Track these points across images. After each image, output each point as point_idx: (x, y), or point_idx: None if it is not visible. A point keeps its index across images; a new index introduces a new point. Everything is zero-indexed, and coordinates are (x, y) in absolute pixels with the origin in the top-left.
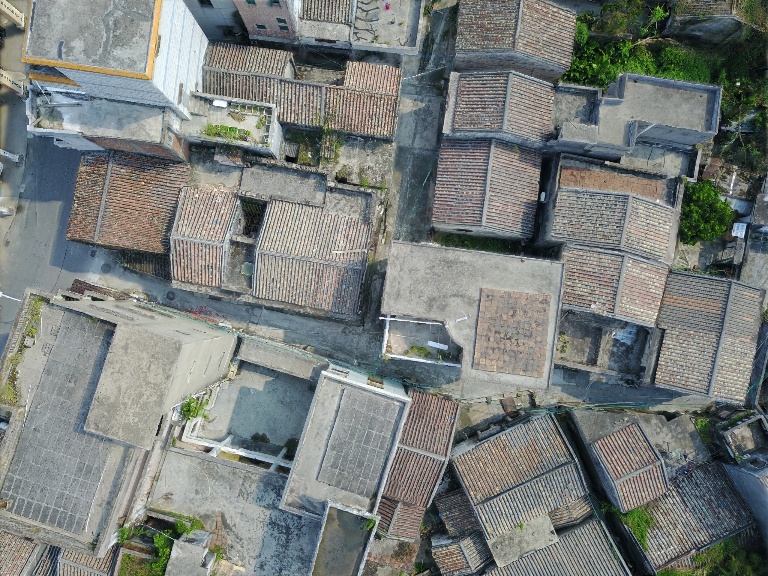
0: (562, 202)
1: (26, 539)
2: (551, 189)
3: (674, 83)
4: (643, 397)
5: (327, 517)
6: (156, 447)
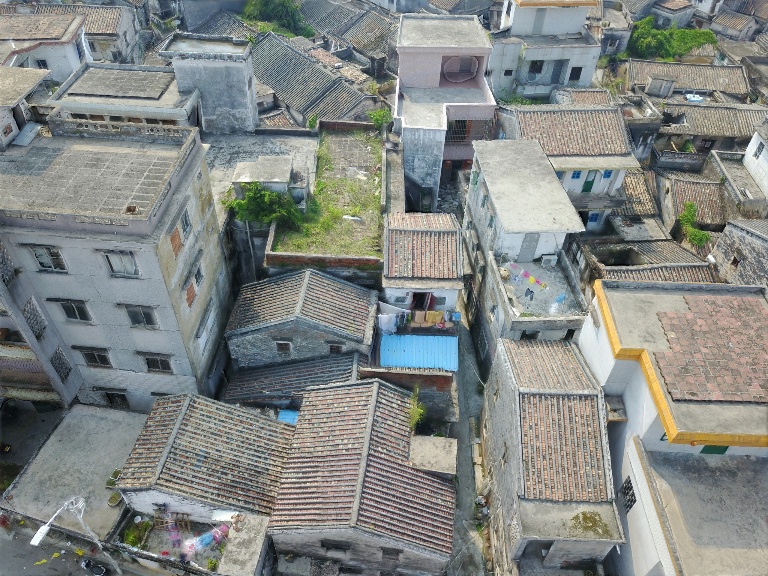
0: None
1: None
2: None
3: None
4: None
5: None
6: None
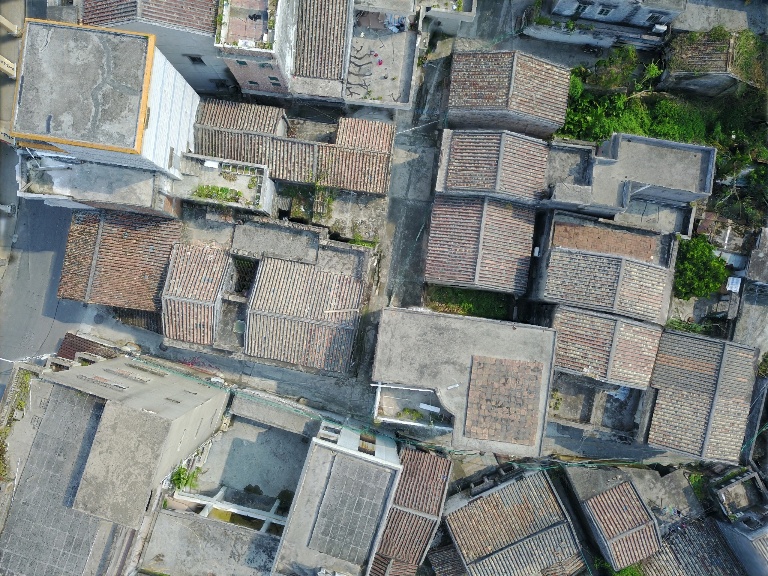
0: (555, 262)
1: None
2: (544, 246)
3: (668, 143)
4: (637, 449)
5: None
6: None
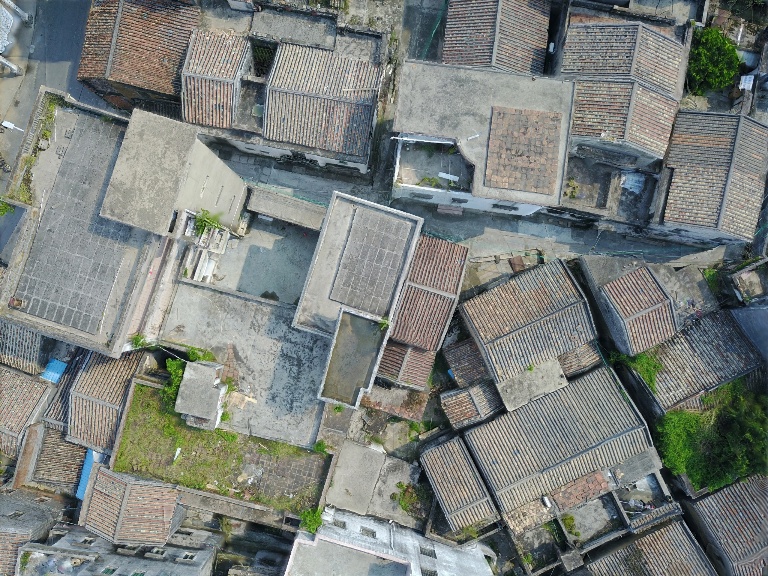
0: (572, 38)
1: (37, 381)
2: (560, 35)
3: None
4: (651, 255)
5: (340, 323)
6: (169, 265)
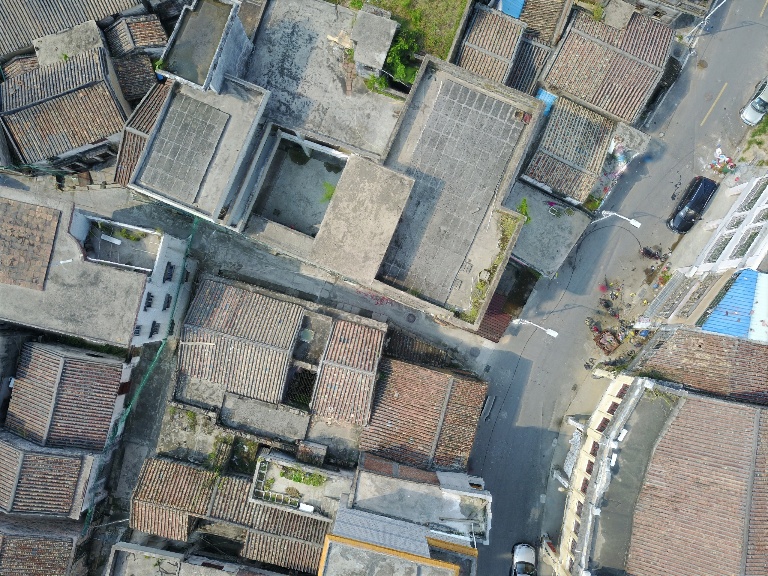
0: None
1: None
2: None
3: None
4: None
5: (208, 76)
6: None
